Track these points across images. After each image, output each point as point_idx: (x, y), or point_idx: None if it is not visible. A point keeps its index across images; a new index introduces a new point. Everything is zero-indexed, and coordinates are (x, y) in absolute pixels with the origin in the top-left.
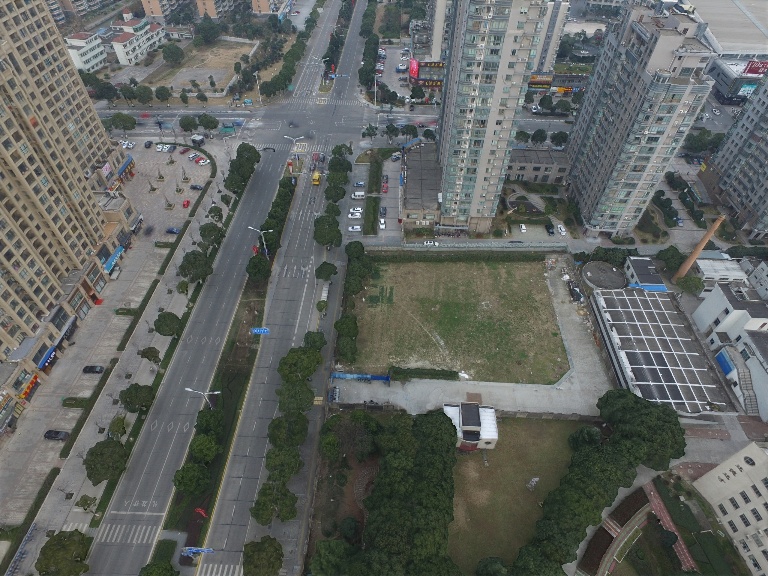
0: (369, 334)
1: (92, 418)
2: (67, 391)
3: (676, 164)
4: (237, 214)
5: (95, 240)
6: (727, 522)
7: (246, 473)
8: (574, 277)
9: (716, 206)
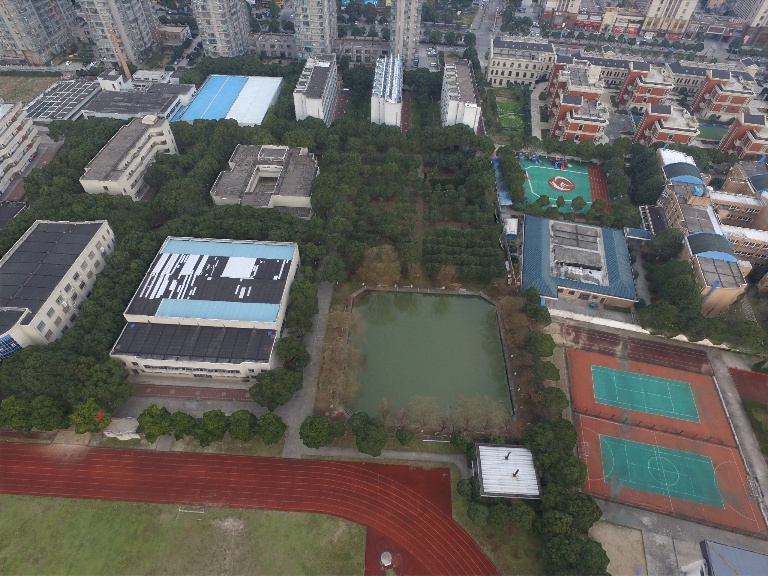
0: None
1: None
2: None
3: None
4: None
5: None
6: None
7: None
8: None
9: None
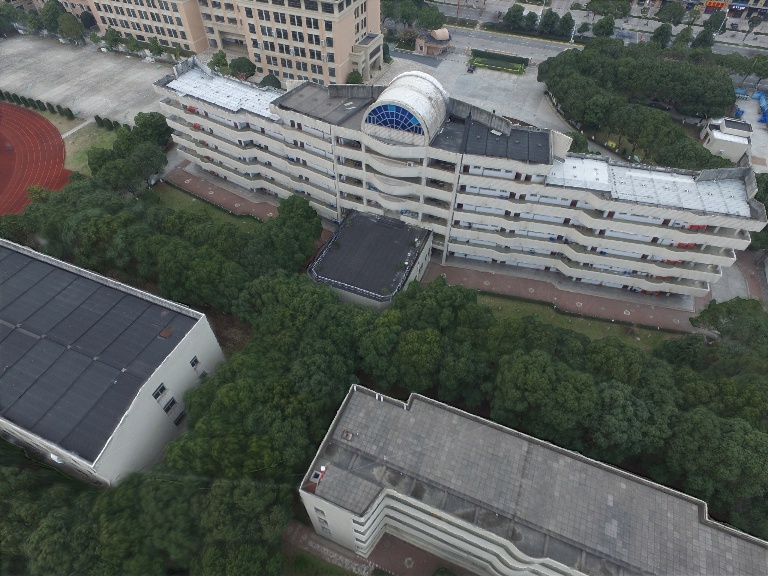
0: None
1: (697, 28)
2: None
3: None
4: None
5: None
6: None
7: None
8: None
9: None
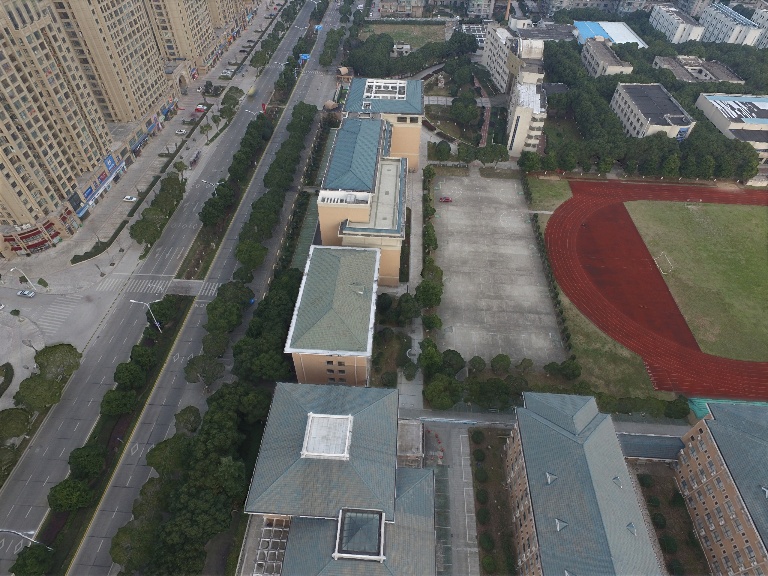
0: (363, 38)
1: None
2: (243, 45)
3: (528, 2)
4: (301, 12)
5: (243, 6)
6: (488, 66)
7: (316, 59)
8: (457, 27)
9: (539, 13)
